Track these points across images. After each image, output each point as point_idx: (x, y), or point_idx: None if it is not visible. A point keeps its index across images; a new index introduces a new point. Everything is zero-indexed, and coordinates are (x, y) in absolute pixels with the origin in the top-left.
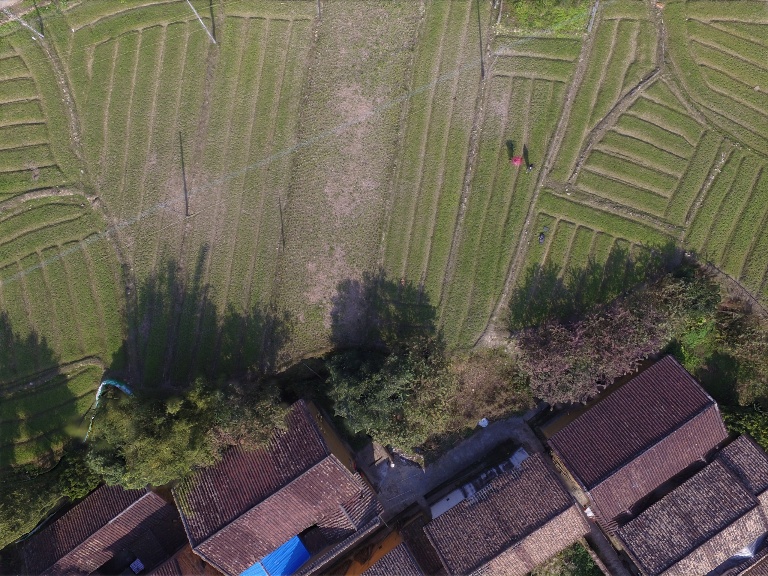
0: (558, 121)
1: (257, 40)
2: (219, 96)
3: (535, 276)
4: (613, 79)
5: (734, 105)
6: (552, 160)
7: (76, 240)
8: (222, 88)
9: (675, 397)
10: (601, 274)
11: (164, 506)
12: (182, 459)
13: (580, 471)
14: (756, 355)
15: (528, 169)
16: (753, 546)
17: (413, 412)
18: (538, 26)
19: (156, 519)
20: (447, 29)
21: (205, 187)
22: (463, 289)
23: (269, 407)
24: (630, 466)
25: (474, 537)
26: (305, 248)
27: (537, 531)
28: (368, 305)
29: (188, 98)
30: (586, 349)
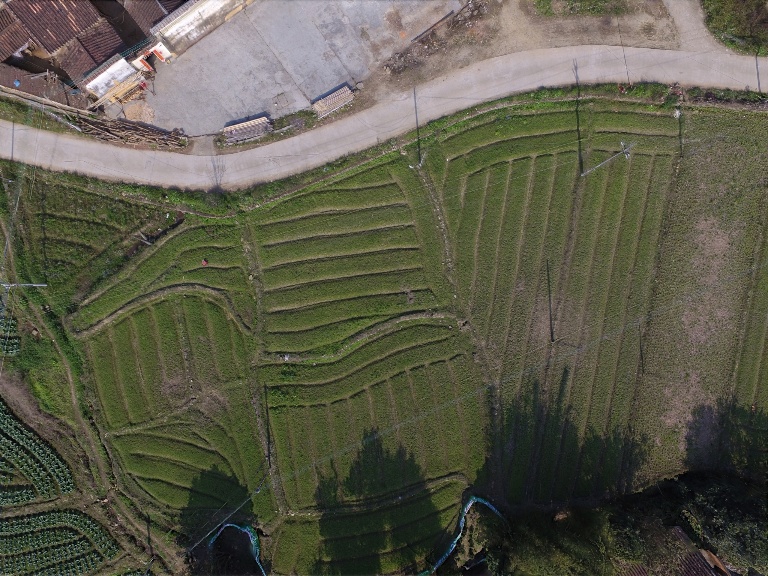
0: None
1: (622, 174)
2: (585, 227)
3: None
4: None
5: None
6: None
7: (443, 360)
8: (588, 219)
9: None
10: None
11: None
12: None
13: None
14: None
15: None
16: None
17: None
18: None
19: None
20: None
21: (570, 313)
22: None
23: None
24: None
25: None
26: (662, 374)
27: None
28: (721, 430)
29: (555, 228)
30: None
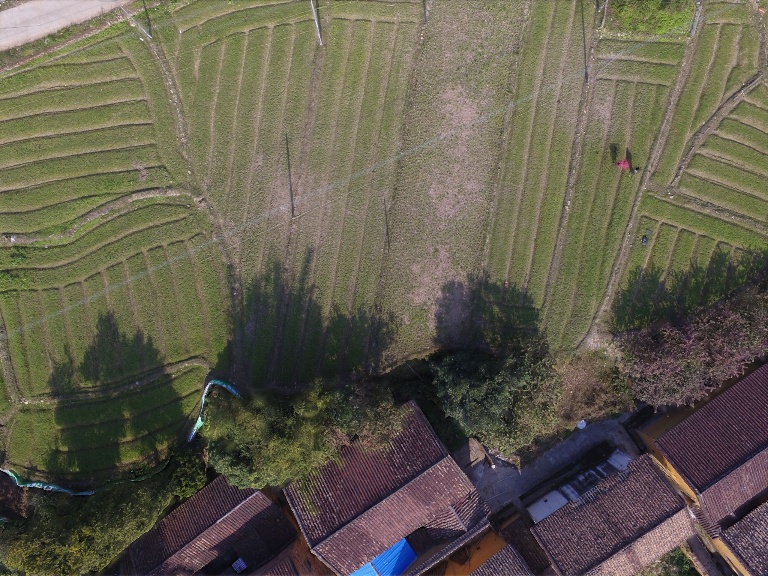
0: (661, 125)
1: (363, 42)
2: (325, 98)
3: (637, 279)
4: (716, 83)
5: None
6: (654, 163)
7: (181, 240)
8: (328, 90)
9: None
10: (703, 277)
11: (270, 506)
12: (308, 459)
13: (690, 473)
14: None
15: (631, 172)
16: None
17: (528, 414)
18: (642, 30)
19: (261, 519)
20: (551, 32)
21: (311, 188)
22: (566, 291)
23: (389, 408)
24: (741, 469)
25: (584, 538)
26: (410, 250)
27: (648, 533)
28: (472, 307)
29: (294, 100)
30: (700, 352)
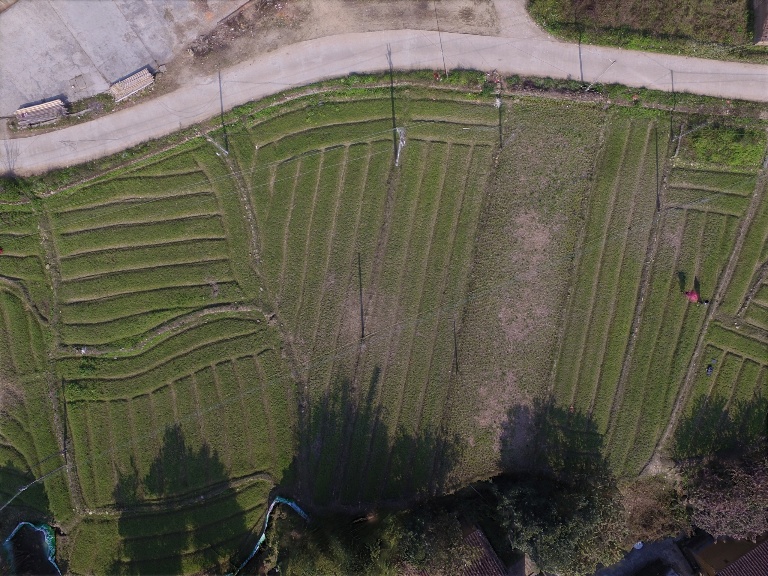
0: (730, 255)
1: (438, 164)
2: (399, 218)
3: (701, 407)
4: None
5: None
6: (722, 293)
7: (250, 355)
8: (402, 211)
9: None
10: (766, 408)
11: None
12: None
13: None
14: None
15: (699, 302)
16: None
17: (597, 553)
18: (714, 160)
19: None
20: (624, 159)
21: (381, 308)
22: (631, 418)
23: (462, 547)
24: None
25: None
26: (477, 372)
27: None
28: (537, 431)
29: (368, 219)
30: None
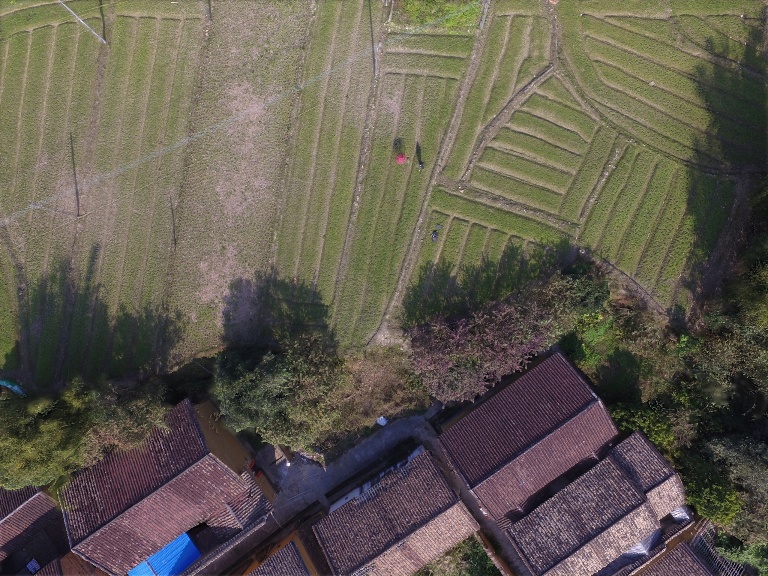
0: (451, 118)
1: (147, 40)
2: (109, 96)
3: (428, 274)
4: (506, 76)
5: (629, 101)
6: (445, 157)
7: None
8: (112, 88)
9: (561, 394)
10: (495, 271)
11: (56, 506)
12: (53, 459)
13: (465, 469)
14: (649, 352)
15: (420, 167)
16: (648, 543)
17: (293, 411)
18: (430, 23)
19: (49, 519)
20: (339, 27)
21: (96, 187)
22: (356, 287)
23: (145, 407)
24: (514, 464)
25: (360, 536)
26: (197, 247)
27: (421, 529)
28: (260, 304)
29: (78, 98)
30: (467, 347)
